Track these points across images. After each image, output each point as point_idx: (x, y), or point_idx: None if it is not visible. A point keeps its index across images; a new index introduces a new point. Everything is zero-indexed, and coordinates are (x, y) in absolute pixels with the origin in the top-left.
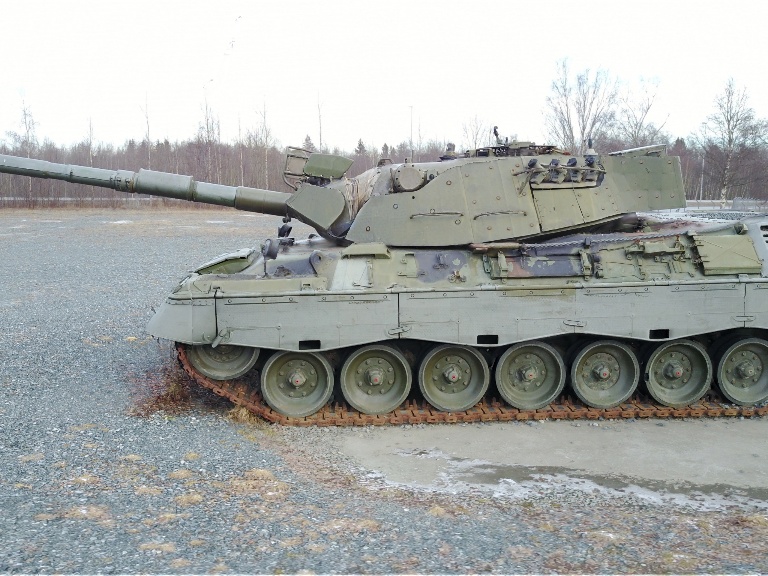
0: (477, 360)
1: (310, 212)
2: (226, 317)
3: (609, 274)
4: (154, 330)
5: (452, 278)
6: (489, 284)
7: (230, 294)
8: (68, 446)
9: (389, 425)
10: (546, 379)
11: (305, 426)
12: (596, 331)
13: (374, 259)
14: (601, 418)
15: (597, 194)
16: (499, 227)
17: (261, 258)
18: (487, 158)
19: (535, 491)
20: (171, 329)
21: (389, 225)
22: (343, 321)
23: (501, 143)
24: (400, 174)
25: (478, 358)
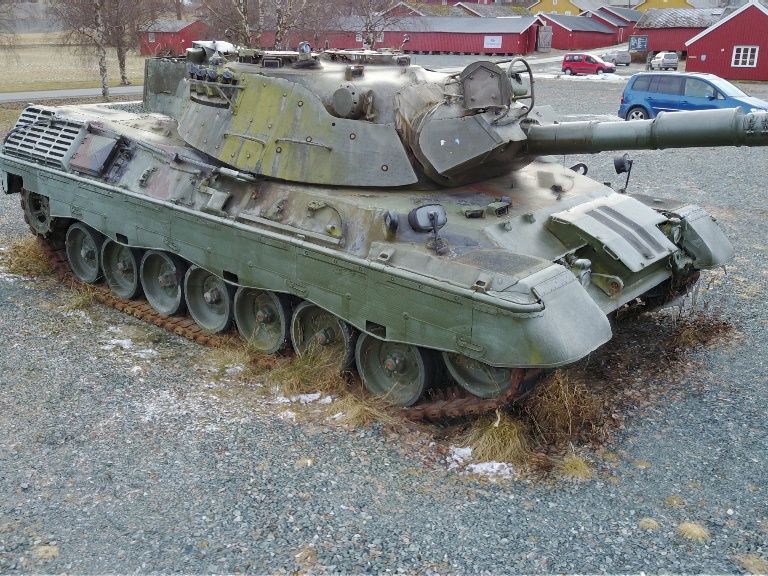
0: None
1: None
2: None
3: None
4: None
5: None
6: None
7: None
8: None
9: None
10: None
11: None
12: None
13: None
14: None
15: None
16: None
17: (597, 195)
18: None
19: None
20: None
21: None
22: None
23: None
24: None
25: None
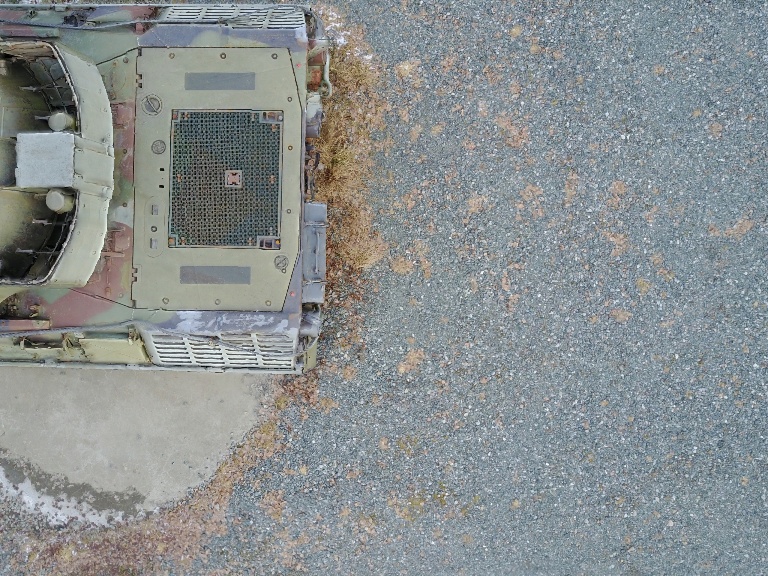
0: None
1: None
2: None
3: (1, 354)
4: None
5: None
6: None
7: None
8: None
9: None
10: None
11: None
12: None
13: None
14: None
15: None
16: None
17: None
18: None
19: None
20: None
21: None
22: None
23: None
24: None
25: None
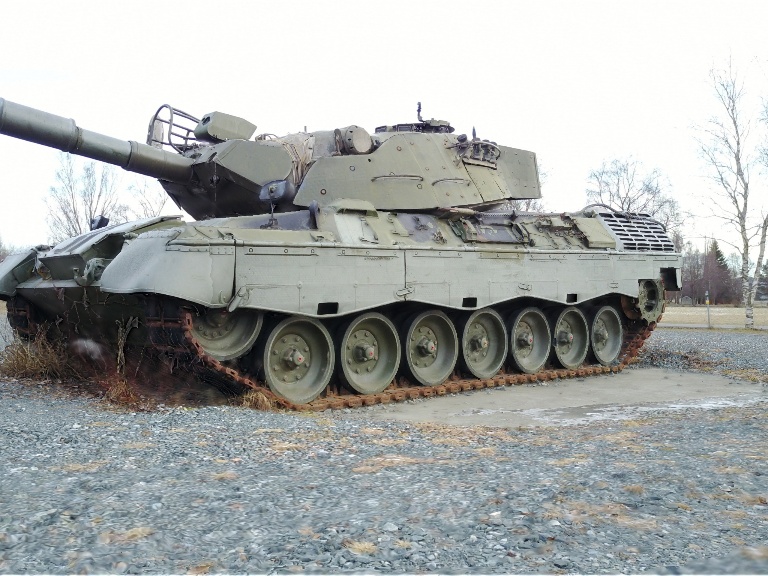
0: (449, 329)
1: (249, 171)
2: (245, 271)
3: (536, 243)
4: (163, 286)
5: (437, 239)
6: (467, 246)
7: (251, 241)
8: (153, 433)
9: (391, 403)
10: (489, 349)
11: (321, 410)
12: (538, 295)
13: (365, 216)
14: (538, 381)
15: (499, 176)
16: (455, 194)
17: None
18: (413, 132)
19: (631, 414)
20: (185, 285)
21: (349, 187)
22: (359, 279)
23: (421, 120)
24: (354, 134)
25: (450, 326)
